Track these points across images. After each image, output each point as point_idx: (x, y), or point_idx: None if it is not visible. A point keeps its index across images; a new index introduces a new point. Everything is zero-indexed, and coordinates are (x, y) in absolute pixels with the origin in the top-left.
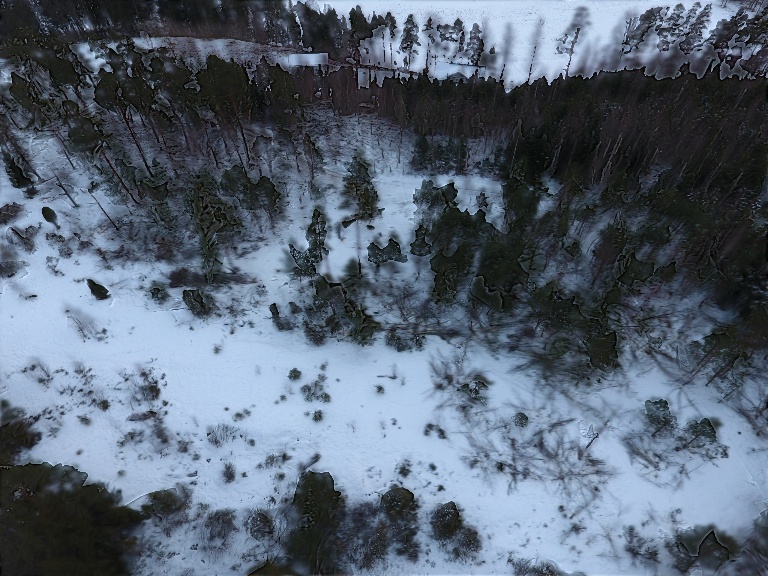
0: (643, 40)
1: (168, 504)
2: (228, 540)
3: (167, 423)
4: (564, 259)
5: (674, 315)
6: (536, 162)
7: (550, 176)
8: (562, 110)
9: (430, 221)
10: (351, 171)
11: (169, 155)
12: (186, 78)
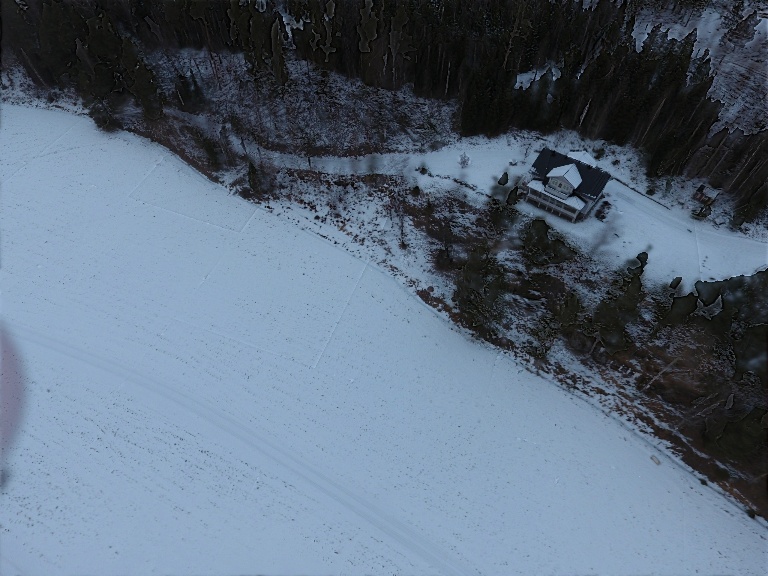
0: None
1: None
2: None
3: None
4: None
5: None
6: None
7: None
8: None
9: None
10: None
11: None
12: None
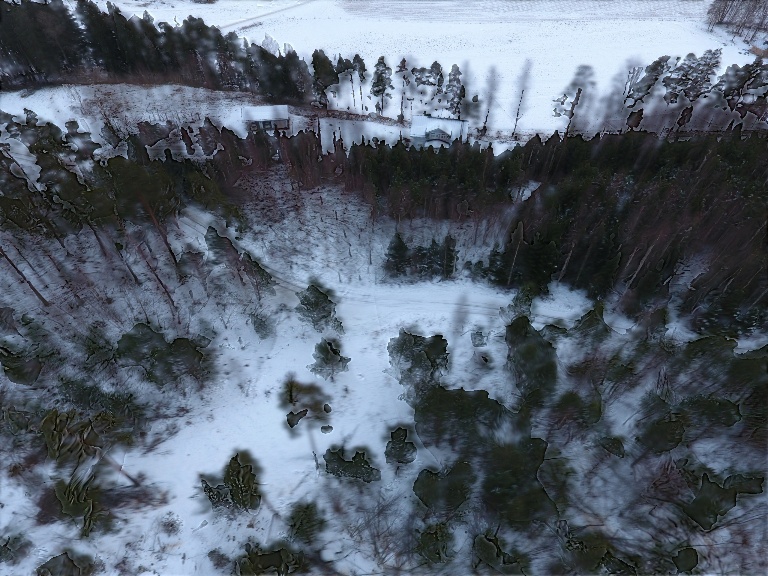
0: None
1: None
2: None
3: None
4: (591, 428)
5: (747, 518)
6: (542, 272)
7: (558, 281)
8: (567, 194)
9: (411, 385)
10: (305, 304)
11: (66, 280)
12: (76, 191)
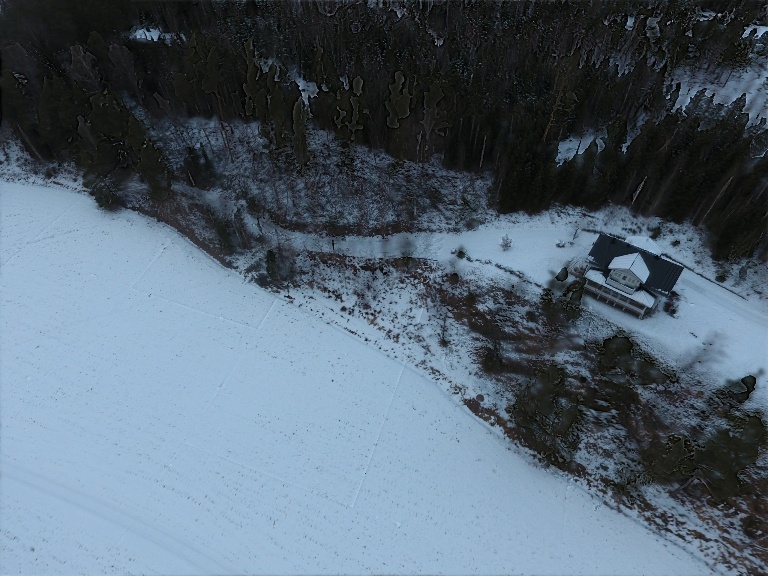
0: (422, 121)
1: None
2: None
3: None
4: None
5: None
6: None
7: None
8: None
9: None
10: None
11: None
12: None
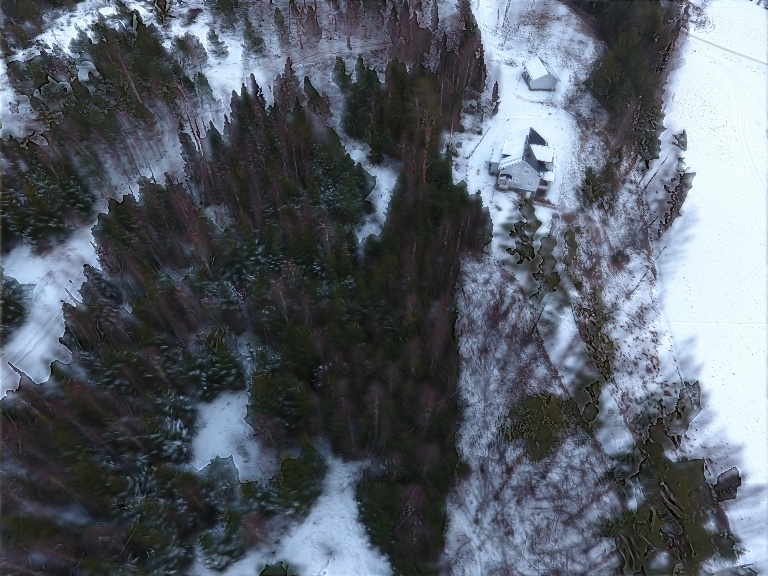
0: None
1: (64, 1)
2: (50, 18)
3: (106, 7)
4: None
5: None
6: None
7: None
8: None
9: None
10: None
11: None
12: None
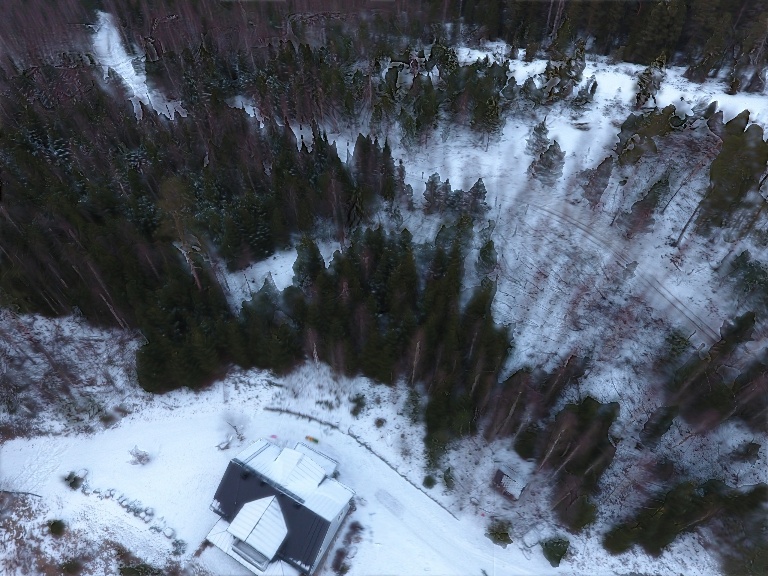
0: None
1: None
2: (589, 58)
3: None
4: None
5: None
6: None
7: None
8: None
9: None
10: None
11: None
12: None
